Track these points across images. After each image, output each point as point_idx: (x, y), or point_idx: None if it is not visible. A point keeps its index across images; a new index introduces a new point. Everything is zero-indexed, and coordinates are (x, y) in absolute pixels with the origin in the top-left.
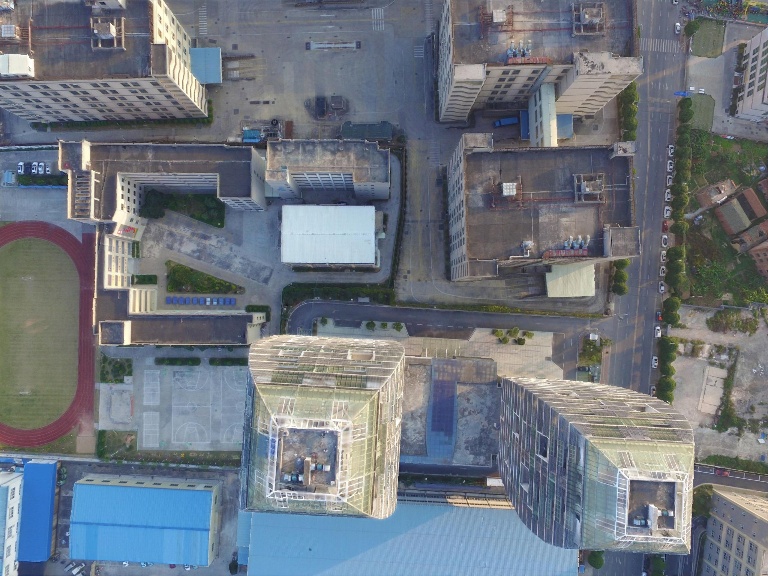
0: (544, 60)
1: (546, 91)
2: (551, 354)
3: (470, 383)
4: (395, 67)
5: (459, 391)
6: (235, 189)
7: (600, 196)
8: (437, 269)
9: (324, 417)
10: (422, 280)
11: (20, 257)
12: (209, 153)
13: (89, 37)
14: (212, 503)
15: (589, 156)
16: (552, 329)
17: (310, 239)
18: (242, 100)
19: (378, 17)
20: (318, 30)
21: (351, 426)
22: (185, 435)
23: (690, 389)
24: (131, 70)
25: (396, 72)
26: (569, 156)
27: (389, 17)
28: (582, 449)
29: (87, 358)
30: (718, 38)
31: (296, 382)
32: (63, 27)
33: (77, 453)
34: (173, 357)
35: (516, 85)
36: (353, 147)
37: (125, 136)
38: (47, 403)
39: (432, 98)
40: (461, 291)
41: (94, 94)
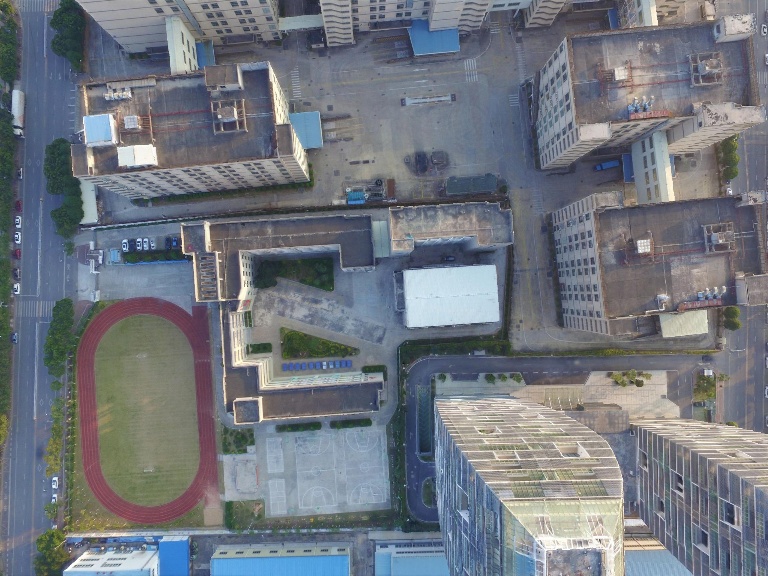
0: (665, 113)
1: (658, 139)
2: (666, 392)
3: (603, 433)
4: (492, 117)
5: None
6: (357, 258)
7: (730, 245)
8: (549, 316)
9: (585, 535)
10: (535, 328)
11: (131, 335)
12: (328, 224)
13: (210, 121)
14: (349, 567)
15: (715, 206)
16: (665, 367)
17: (435, 302)
18: (342, 161)
19: (471, 68)
20: (412, 85)
21: (612, 542)
22: (312, 500)
23: None
24: (254, 151)
25: (493, 122)
26: (696, 207)
27: (482, 67)
28: None
29: (207, 431)
30: None
31: (539, 495)
32: (183, 113)
33: (205, 526)
34: (294, 423)
35: (628, 134)
36: (474, 209)
37: (227, 206)
38: (171, 478)
39: (531, 146)
40: (574, 336)
41: (211, 174)
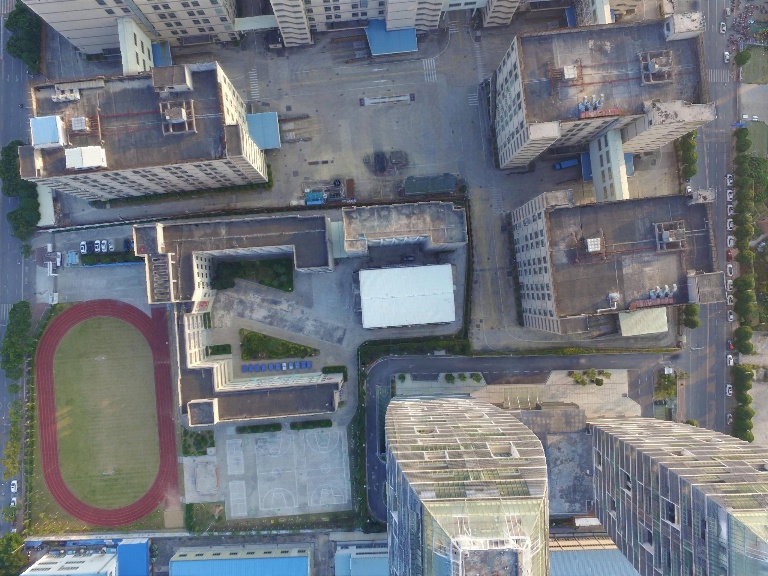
0: (616, 112)
1: (613, 137)
2: (627, 390)
3: (560, 432)
4: (451, 117)
5: (550, 441)
6: (312, 259)
7: (681, 243)
8: (509, 316)
9: (502, 535)
10: (495, 328)
11: (90, 337)
12: (282, 225)
13: (159, 122)
14: (308, 568)
15: (667, 204)
16: (626, 366)
17: (390, 302)
18: (301, 162)
19: (430, 68)
20: (371, 85)
21: (529, 542)
22: (272, 501)
23: (765, 413)
24: (204, 152)
25: (452, 122)
26: (647, 205)
27: (441, 67)
28: (724, 523)
29: (167, 433)
30: (767, 64)
31: (461, 496)
32: (131, 114)
33: (166, 528)
34: (254, 425)
35: (582, 133)
36: (428, 209)
37: (186, 207)
38: (131, 481)
39: (490, 145)
40: (534, 336)
41: (163, 175)
